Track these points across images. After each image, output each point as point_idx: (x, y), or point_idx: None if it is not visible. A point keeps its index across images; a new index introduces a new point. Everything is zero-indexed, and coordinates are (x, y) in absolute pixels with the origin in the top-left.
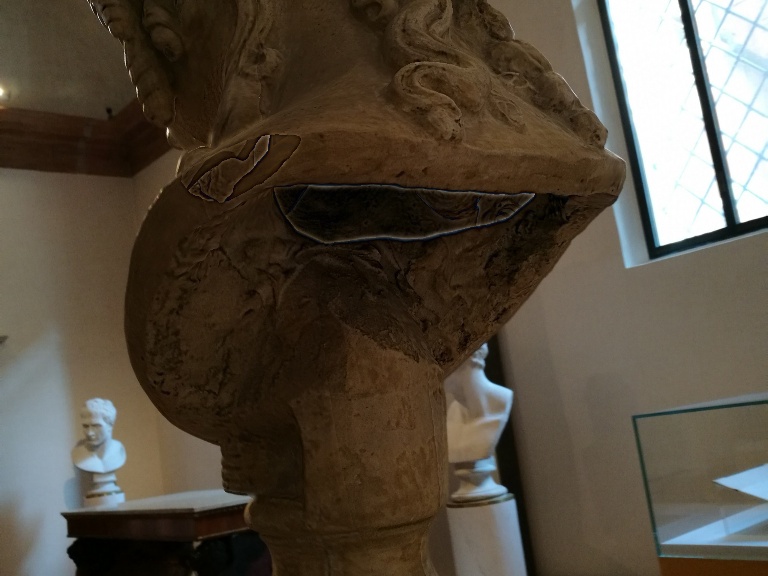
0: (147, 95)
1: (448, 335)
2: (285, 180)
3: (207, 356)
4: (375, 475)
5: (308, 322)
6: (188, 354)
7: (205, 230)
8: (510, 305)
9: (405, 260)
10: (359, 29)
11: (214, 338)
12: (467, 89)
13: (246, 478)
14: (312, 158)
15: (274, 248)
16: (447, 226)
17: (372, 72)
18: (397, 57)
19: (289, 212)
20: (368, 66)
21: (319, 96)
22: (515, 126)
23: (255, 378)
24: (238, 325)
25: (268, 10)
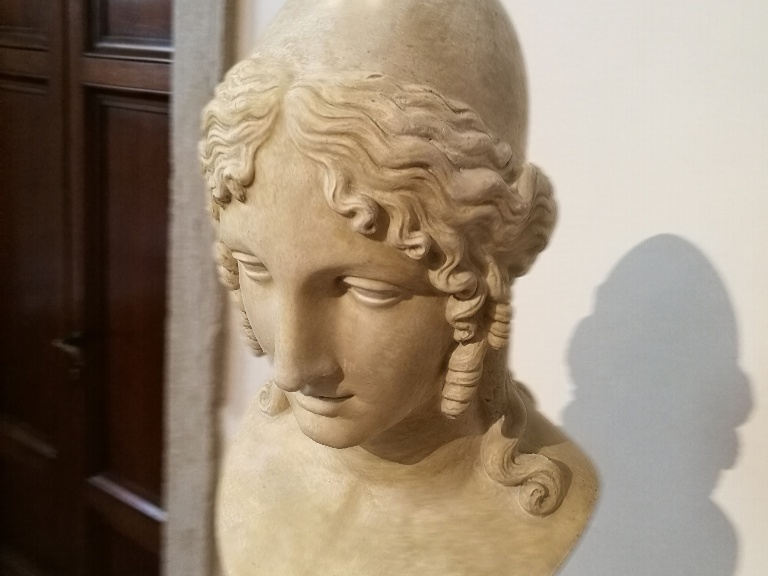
0: None
1: None
2: None
3: None
4: None
5: None
6: None
7: None
8: None
9: None
10: None
11: None
12: None
13: None
14: None
15: None
16: None
17: None
18: None
19: (365, 449)
20: None
21: None
22: None
23: None
24: None
25: None
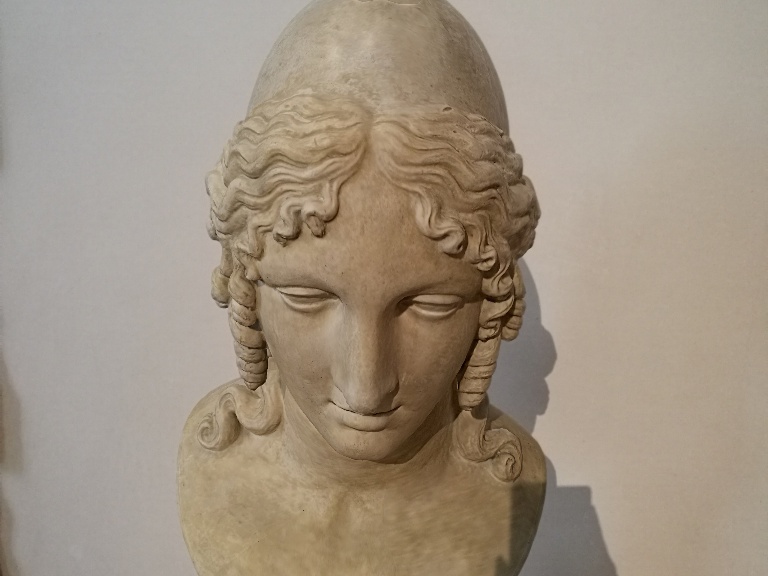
0: None
1: None
2: None
3: None
4: None
5: None
6: None
7: None
8: None
9: None
10: None
11: None
12: None
13: None
14: None
15: None
16: (264, 442)
17: None
18: None
19: None
20: None
21: None
22: None
23: None
24: None
25: None
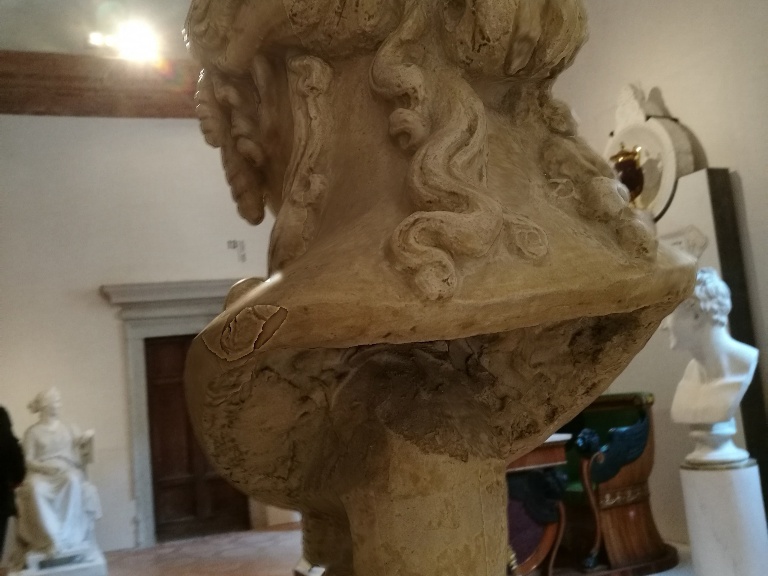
0: (237, 197)
1: (532, 409)
2: (278, 346)
3: (273, 449)
4: (415, 571)
5: (359, 423)
6: (249, 453)
7: (232, 371)
8: (600, 380)
9: (478, 344)
10: (393, 155)
11: (275, 436)
12: (466, 239)
13: (315, 552)
14: (298, 329)
15: (326, 356)
16: None
17: (392, 210)
18: (413, 196)
19: None
20: (390, 202)
21: (330, 246)
22: (533, 259)
23: (318, 467)
24: (297, 423)
25: (317, 135)
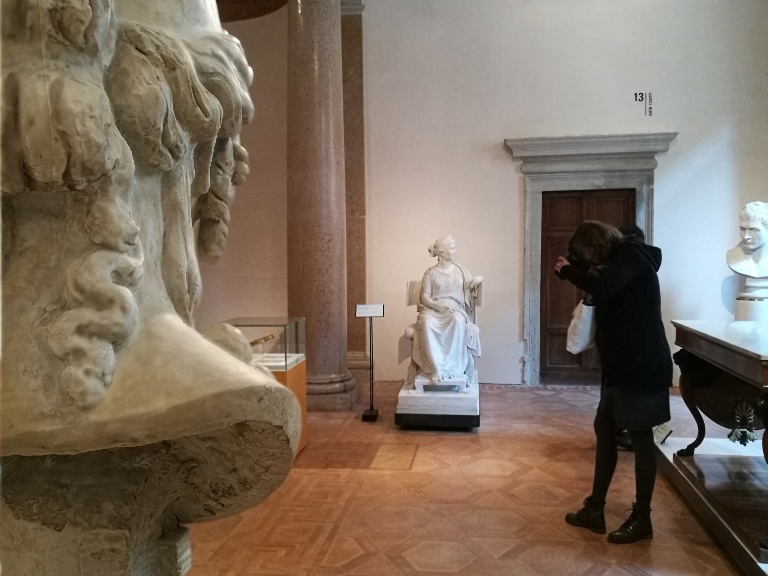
0: None
1: (223, 475)
2: None
3: None
4: None
5: None
6: None
7: None
8: (270, 464)
9: None
10: None
11: None
12: None
13: None
14: None
15: None
16: None
17: None
18: None
19: None
20: None
21: None
22: None
23: None
24: None
25: None
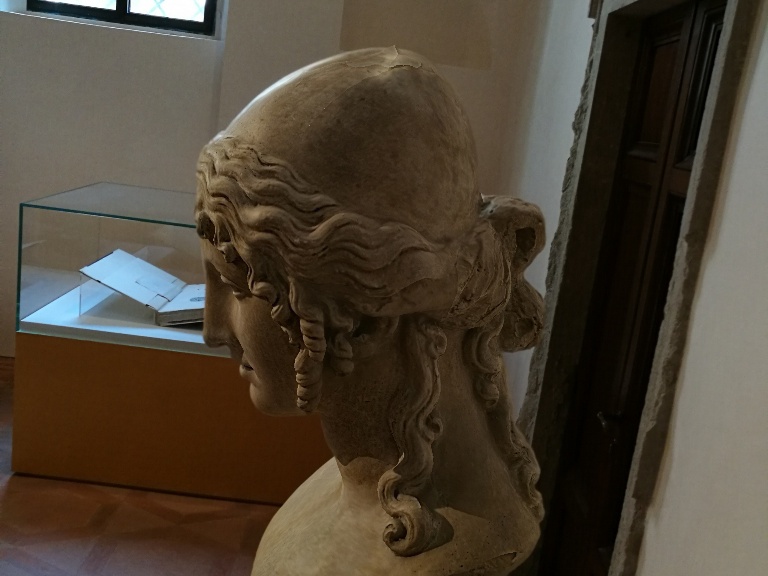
0: (314, 398)
1: None
2: None
3: None
4: None
5: None
6: None
7: None
8: None
9: None
10: (478, 409)
11: None
12: None
13: None
14: None
15: None
16: None
17: (495, 455)
18: (508, 449)
19: None
20: (491, 448)
21: (497, 494)
22: None
23: None
24: None
25: None
